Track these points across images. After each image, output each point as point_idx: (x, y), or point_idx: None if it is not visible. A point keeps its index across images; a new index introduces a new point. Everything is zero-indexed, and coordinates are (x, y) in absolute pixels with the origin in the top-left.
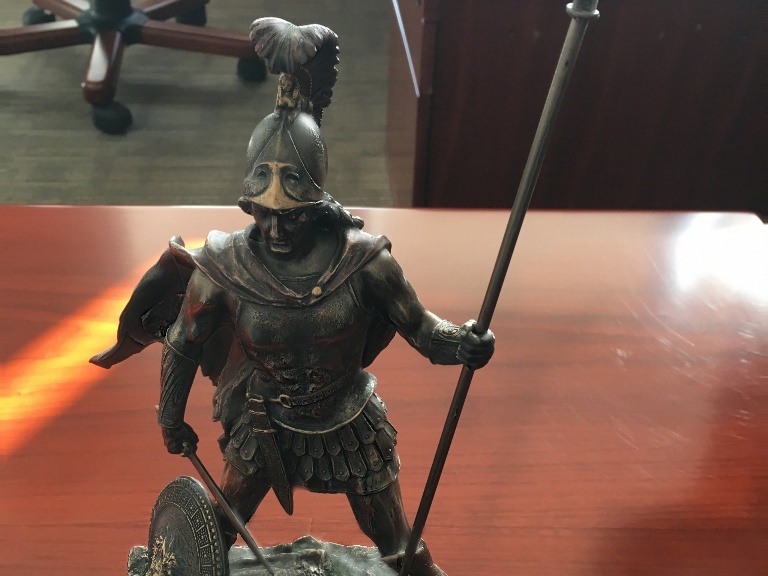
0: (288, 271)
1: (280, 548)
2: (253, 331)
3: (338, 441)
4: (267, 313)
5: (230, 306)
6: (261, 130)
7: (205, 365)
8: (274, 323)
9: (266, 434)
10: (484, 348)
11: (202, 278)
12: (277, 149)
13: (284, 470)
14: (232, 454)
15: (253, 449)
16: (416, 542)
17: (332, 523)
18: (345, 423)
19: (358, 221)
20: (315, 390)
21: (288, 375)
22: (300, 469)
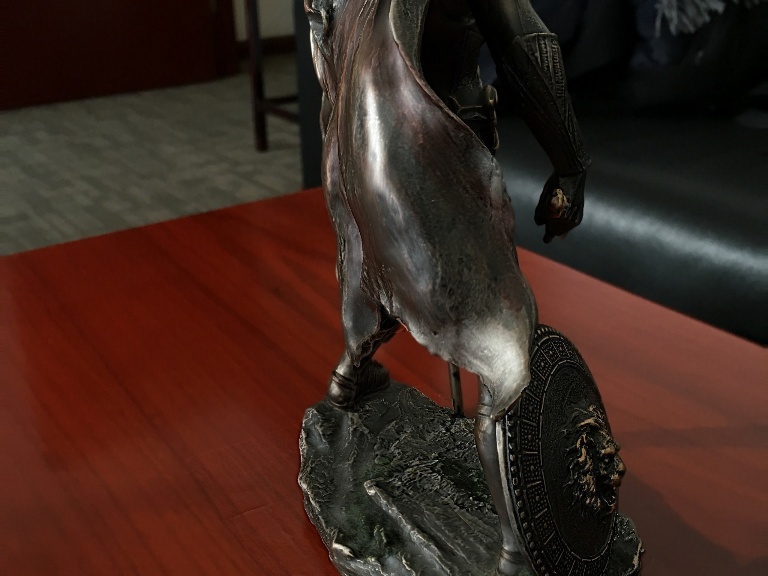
0: None
1: (389, 536)
2: None
3: None
4: None
5: None
6: None
7: None
8: None
9: None
10: None
11: None
12: None
13: None
14: None
15: None
16: None
17: None
18: None
19: None
20: None
21: None
22: None
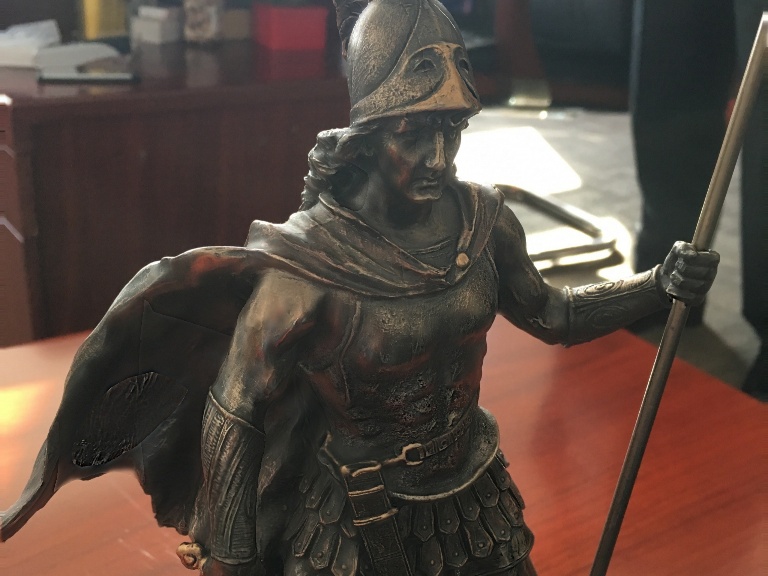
0: (412, 242)
1: None
2: (385, 344)
3: (474, 497)
4: (401, 310)
5: (334, 318)
6: (393, 8)
7: (160, 492)
8: (413, 323)
9: (381, 521)
10: (714, 268)
11: (289, 281)
12: (437, 26)
13: (410, 571)
14: None
15: (354, 558)
16: None
17: None
18: (487, 463)
19: None
20: (455, 422)
21: (424, 407)
22: (421, 564)
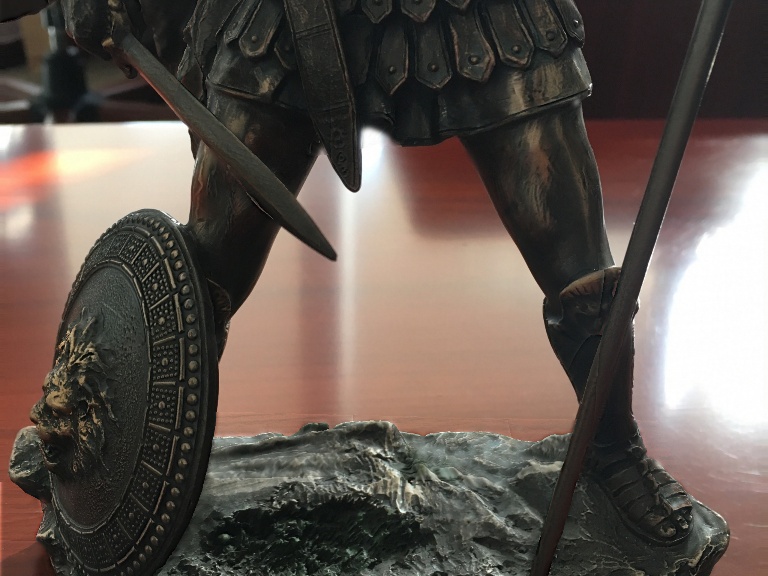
0: None
1: (306, 430)
2: None
3: None
4: None
5: None
6: None
7: (163, 26)
8: None
9: None
10: None
11: None
12: None
13: (343, 59)
14: (221, 68)
15: (270, 28)
16: (660, 205)
17: (389, 420)
18: None
19: None
20: None
21: None
22: (377, 71)
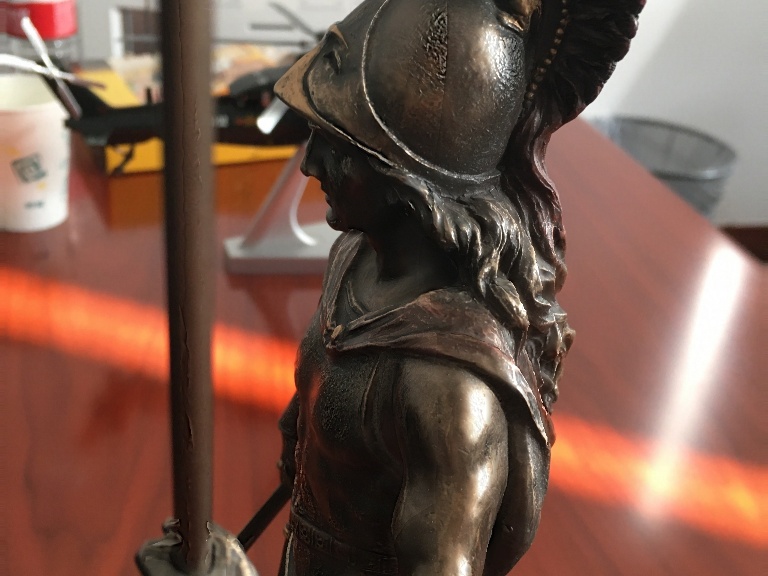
0: (364, 284)
1: None
2: None
3: None
4: None
5: None
6: None
7: None
8: (308, 344)
9: None
10: None
11: None
12: None
13: None
14: None
15: None
16: None
17: None
18: None
19: (500, 298)
20: None
21: None
22: None
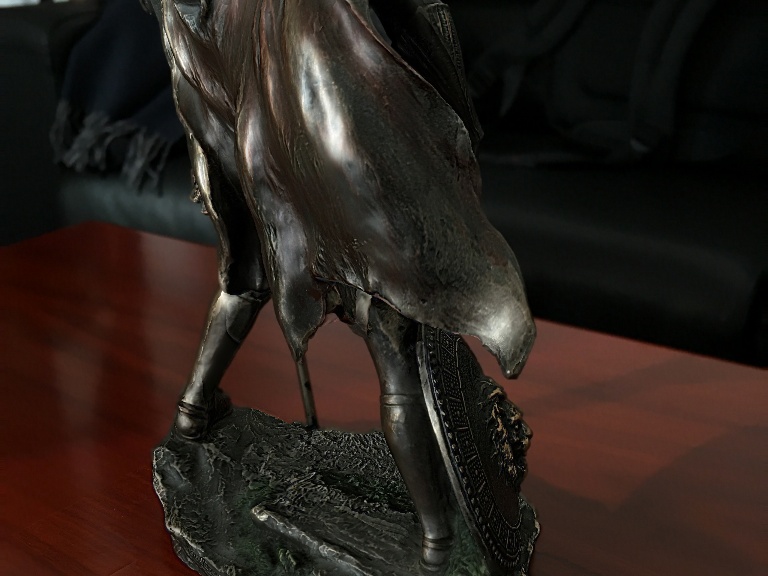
0: None
1: (297, 557)
2: None
3: None
4: None
5: None
6: None
7: None
8: None
9: None
10: None
11: None
12: None
13: None
14: None
15: None
16: None
17: None
18: None
19: None
20: None
21: None
22: None
